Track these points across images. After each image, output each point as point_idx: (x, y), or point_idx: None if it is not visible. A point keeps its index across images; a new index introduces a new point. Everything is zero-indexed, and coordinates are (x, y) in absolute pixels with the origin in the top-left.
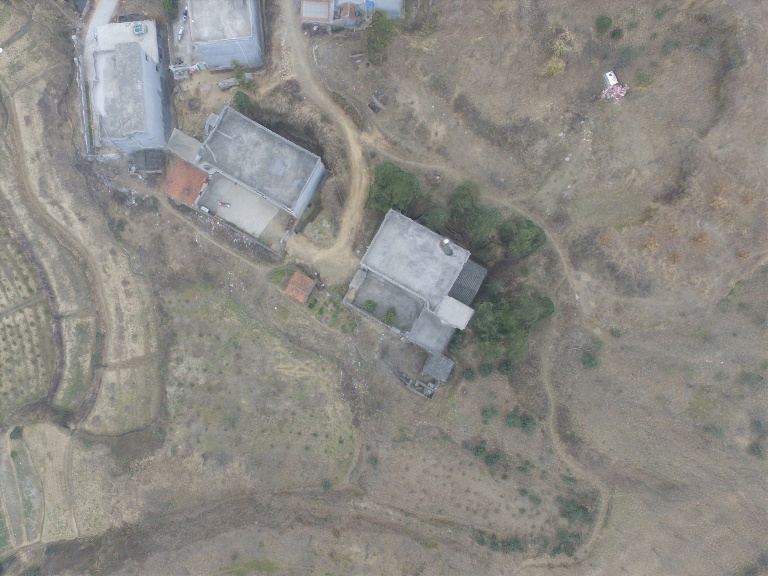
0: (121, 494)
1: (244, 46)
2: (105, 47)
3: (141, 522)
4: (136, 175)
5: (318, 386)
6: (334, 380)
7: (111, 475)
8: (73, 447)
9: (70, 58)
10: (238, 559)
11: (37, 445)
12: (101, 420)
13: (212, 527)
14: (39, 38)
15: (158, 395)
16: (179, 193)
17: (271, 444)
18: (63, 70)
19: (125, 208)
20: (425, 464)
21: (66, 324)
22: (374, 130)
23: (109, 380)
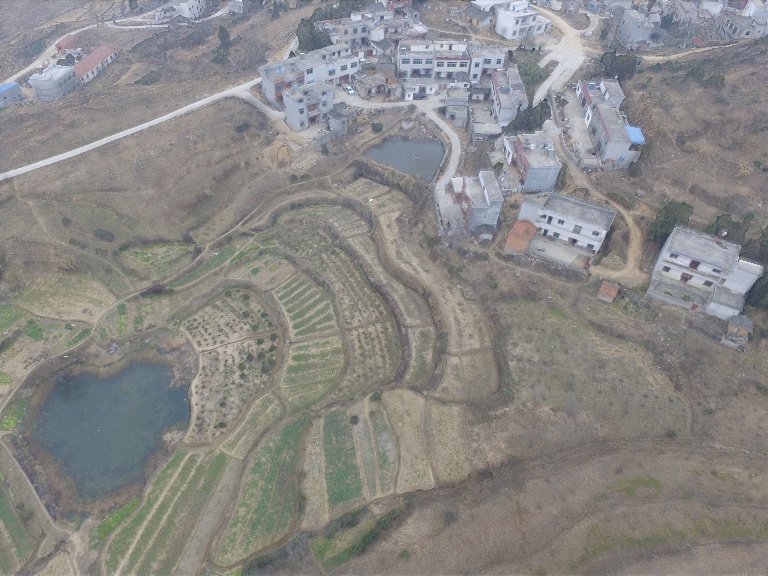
0: (482, 438)
1: (553, 174)
2: (457, 185)
3: (506, 462)
4: (473, 241)
5: (635, 362)
6: (647, 358)
7: (470, 423)
8: (430, 405)
9: (425, 196)
10: (625, 475)
11: (396, 404)
12: (449, 390)
13: (582, 459)
14: (396, 196)
15: (496, 374)
16: (522, 232)
17: (609, 403)
18: (411, 207)
19: (463, 259)
20: (758, 414)
21: (412, 330)
22: (640, 206)
23: (453, 362)
